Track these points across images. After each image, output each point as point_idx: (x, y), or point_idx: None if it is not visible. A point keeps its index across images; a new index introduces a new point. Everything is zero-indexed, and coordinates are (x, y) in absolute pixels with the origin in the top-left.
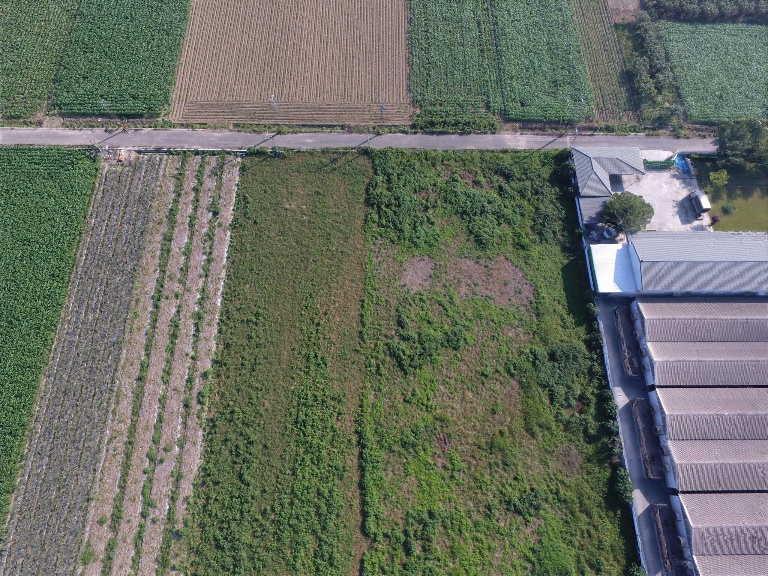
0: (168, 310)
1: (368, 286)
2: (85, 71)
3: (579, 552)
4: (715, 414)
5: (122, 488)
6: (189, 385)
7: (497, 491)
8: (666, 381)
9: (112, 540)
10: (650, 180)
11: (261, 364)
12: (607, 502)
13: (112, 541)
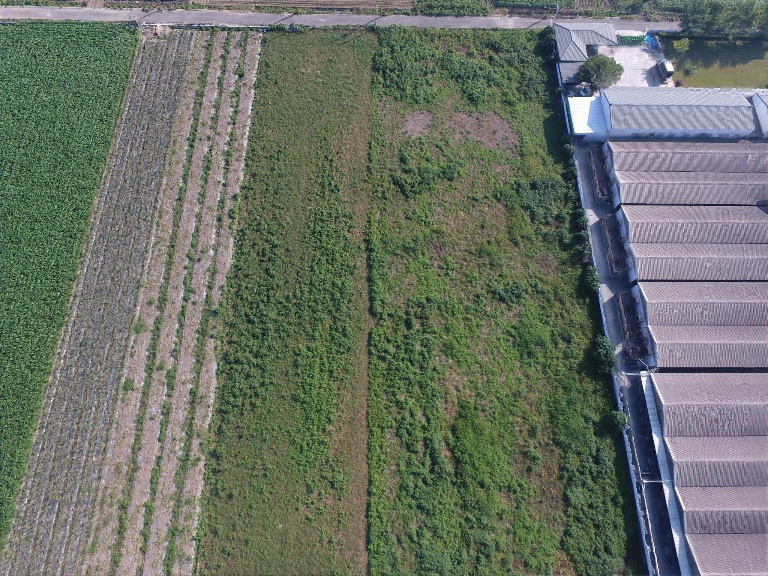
0: (202, 149)
1: (375, 132)
2: None
3: (553, 328)
4: (670, 222)
5: (166, 279)
6: (221, 205)
7: (485, 285)
8: (630, 200)
9: (159, 316)
10: (623, 53)
11: (283, 189)
12: (578, 293)
13: (159, 317)
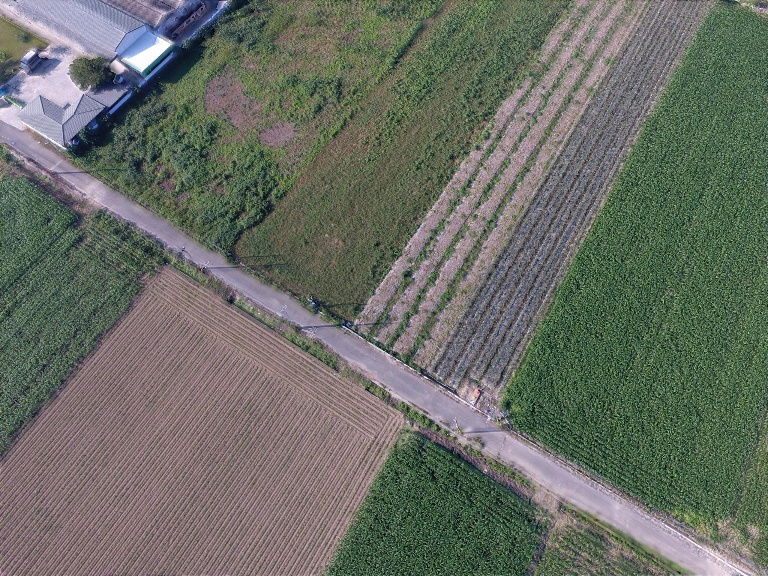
0: (487, 209)
1: None
2: (480, 571)
3: None
4: None
5: (559, 113)
6: (492, 148)
7: (334, 6)
8: None
9: (572, 90)
10: None
11: None
12: None
13: (572, 90)
